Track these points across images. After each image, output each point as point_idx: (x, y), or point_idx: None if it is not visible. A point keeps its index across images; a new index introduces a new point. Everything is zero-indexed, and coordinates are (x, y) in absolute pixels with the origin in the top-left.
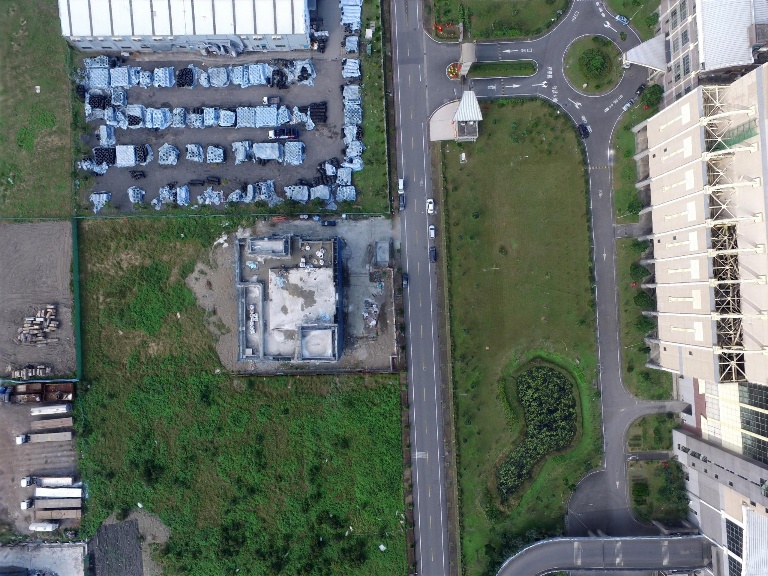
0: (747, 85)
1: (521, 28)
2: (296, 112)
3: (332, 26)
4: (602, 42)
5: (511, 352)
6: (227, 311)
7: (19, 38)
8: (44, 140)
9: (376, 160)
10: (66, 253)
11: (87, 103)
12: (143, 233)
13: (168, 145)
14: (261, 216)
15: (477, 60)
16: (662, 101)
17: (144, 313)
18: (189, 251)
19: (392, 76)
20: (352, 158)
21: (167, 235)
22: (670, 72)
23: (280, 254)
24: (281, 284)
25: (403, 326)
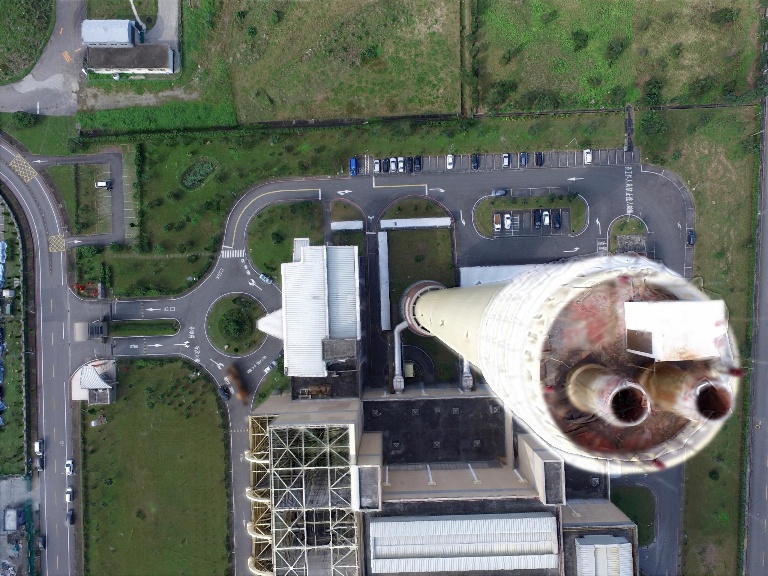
0: None
1: (160, 289)
2: None
3: None
4: (241, 305)
5: None
6: None
7: None
8: None
9: (15, 420)
10: None
11: None
12: None
13: None
14: None
15: (120, 318)
16: None
17: None
18: None
19: (35, 334)
20: None
21: None
22: None
23: None
24: None
25: None
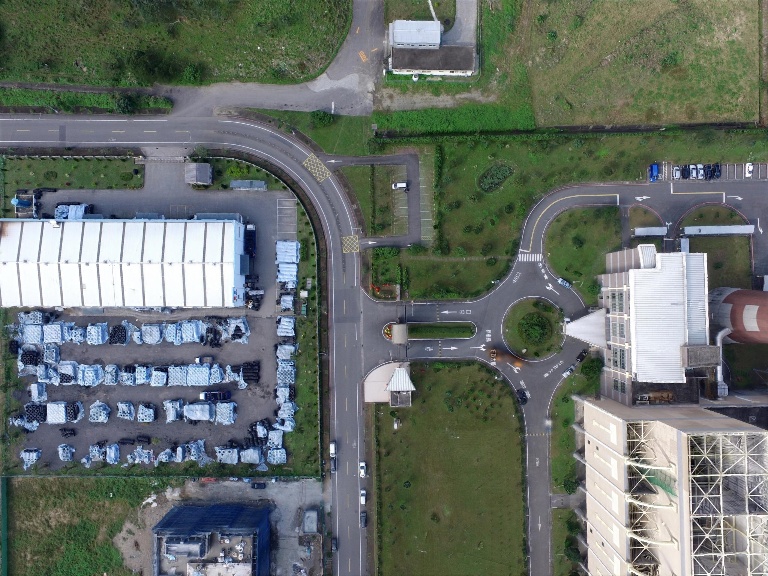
0: (669, 437)
1: (459, 292)
2: (229, 371)
3: (268, 283)
4: (542, 309)
5: None
6: None
7: None
8: None
9: (308, 422)
10: None
11: (19, 361)
12: (72, 492)
13: (99, 402)
14: (190, 477)
15: (414, 320)
16: (602, 374)
17: (71, 573)
18: (118, 510)
19: (327, 334)
20: (284, 419)
21: (96, 494)
22: (609, 351)
23: (196, 557)
24: None
25: None
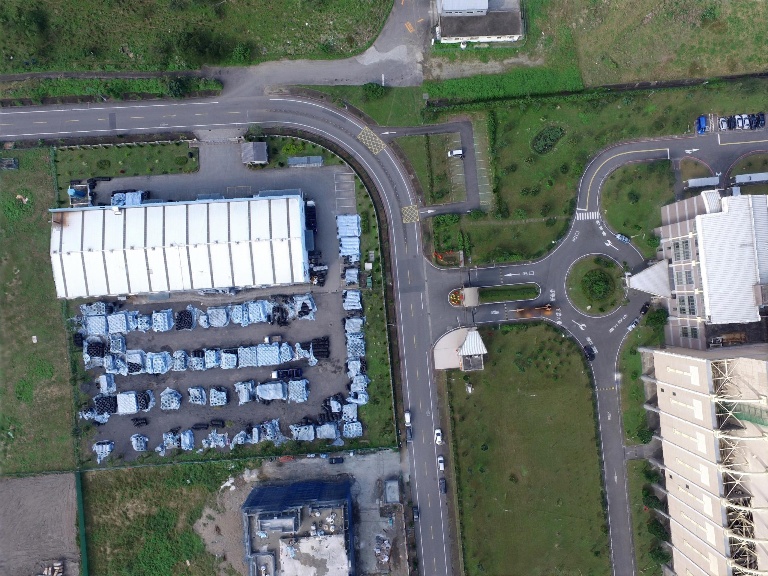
0: (757, 371)
1: (522, 254)
2: (298, 349)
3: (331, 258)
4: (604, 265)
5: None
6: (237, 556)
7: (13, 288)
8: (43, 391)
9: (381, 393)
10: (71, 506)
11: (85, 353)
12: (148, 481)
13: (170, 389)
14: (267, 457)
15: (479, 285)
16: (667, 324)
17: (153, 563)
18: (196, 496)
19: (394, 305)
20: (357, 392)
21: (173, 482)
22: (674, 300)
23: (290, 532)
24: (292, 554)
25: (416, 561)
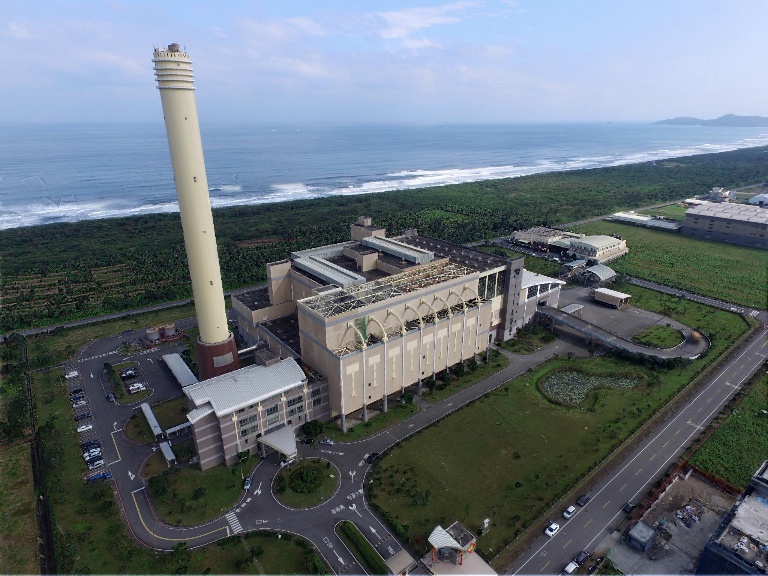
0: (333, 333)
1: None
2: None
3: None
4: (284, 482)
5: (569, 415)
6: None
7: None
8: None
9: None
10: None
11: None
12: None
13: None
14: None
15: None
16: None
17: None
18: None
19: None
20: None
21: None
22: (292, 421)
23: None
24: None
25: (657, 484)
